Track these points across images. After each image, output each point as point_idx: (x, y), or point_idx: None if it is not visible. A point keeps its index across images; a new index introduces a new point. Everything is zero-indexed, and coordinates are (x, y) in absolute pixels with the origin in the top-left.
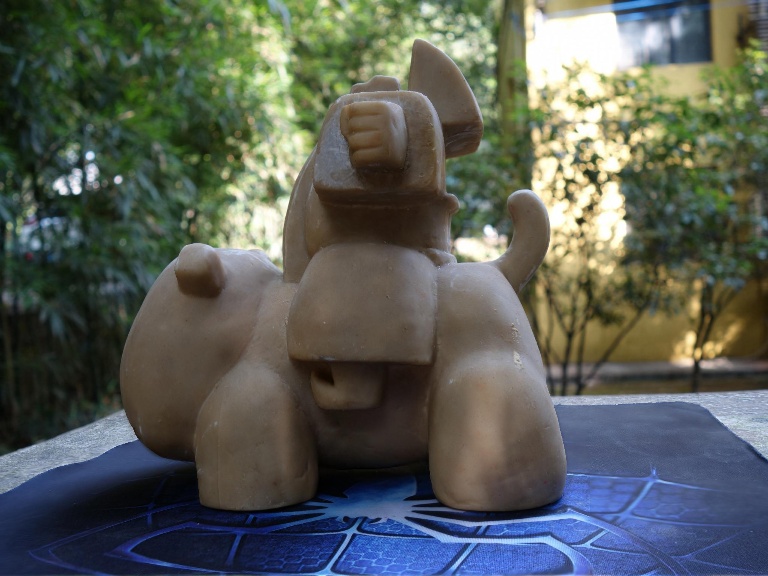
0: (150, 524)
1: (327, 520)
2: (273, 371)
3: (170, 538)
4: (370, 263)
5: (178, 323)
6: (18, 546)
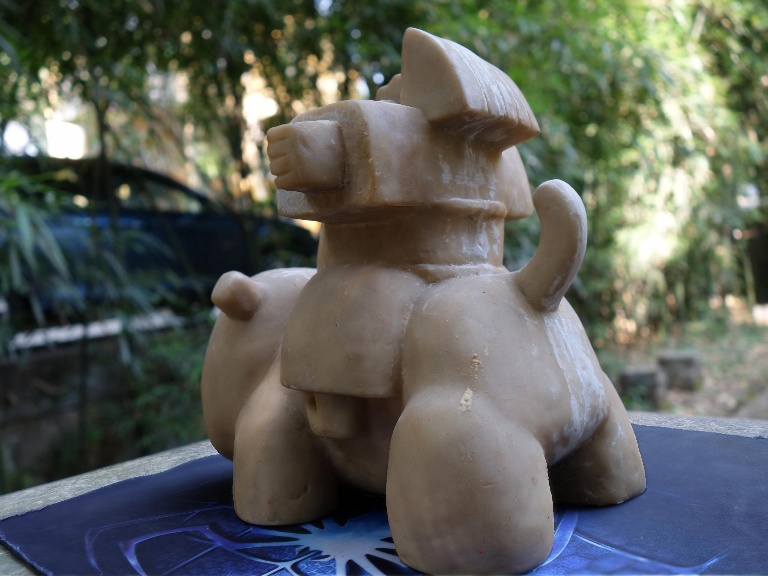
0: (183, 521)
1: (289, 547)
2: (283, 392)
3: (172, 538)
4: (330, 288)
5: (221, 344)
6: (93, 523)
